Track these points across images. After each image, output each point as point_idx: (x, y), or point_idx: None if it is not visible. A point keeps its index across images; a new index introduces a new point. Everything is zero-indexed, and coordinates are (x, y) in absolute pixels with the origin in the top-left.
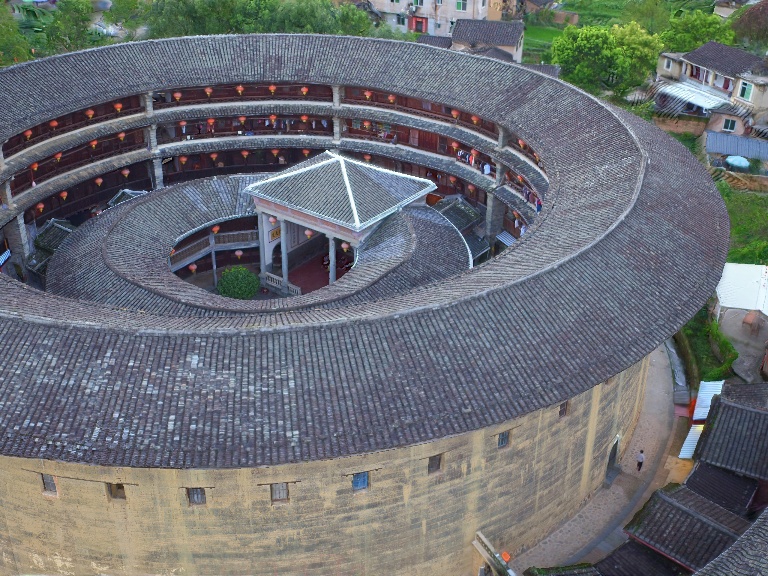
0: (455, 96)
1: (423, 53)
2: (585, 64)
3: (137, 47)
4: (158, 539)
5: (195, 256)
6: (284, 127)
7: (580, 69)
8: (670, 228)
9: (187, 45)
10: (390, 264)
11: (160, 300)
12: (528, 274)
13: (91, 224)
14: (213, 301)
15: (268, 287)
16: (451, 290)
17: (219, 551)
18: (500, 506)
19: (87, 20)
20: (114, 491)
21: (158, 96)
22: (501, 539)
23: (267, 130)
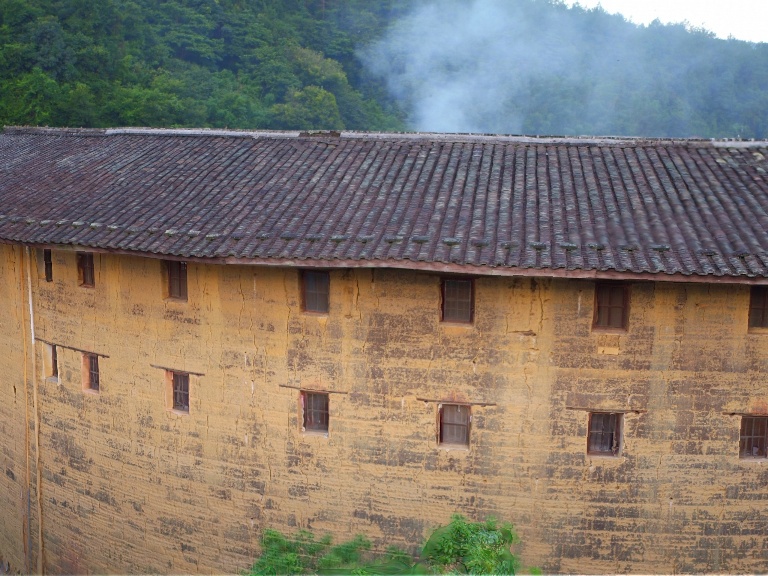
0: None
1: None
2: None
3: None
4: None
5: None
6: None
7: None
8: None
9: None
10: None
11: None
12: None
13: None
14: None
15: None
16: None
17: None
18: None
19: None
20: None
21: None
22: None
23: None
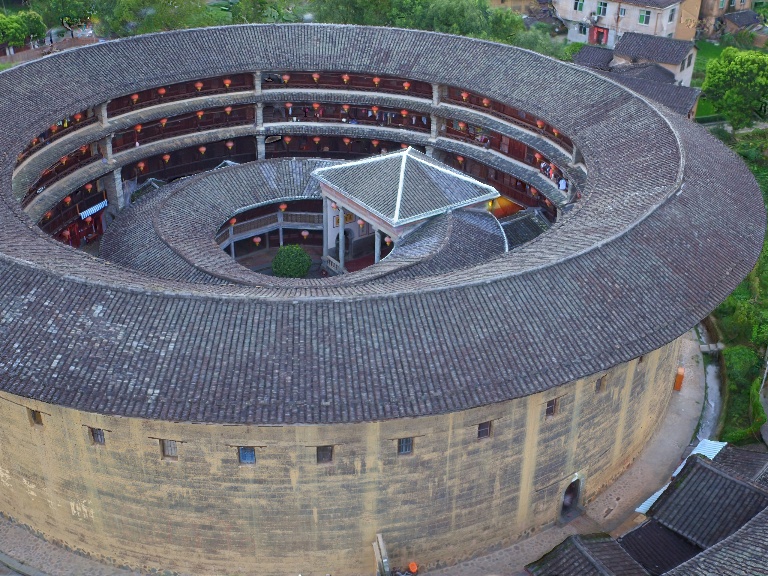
0: (541, 106)
1: (527, 59)
2: (736, 90)
3: (259, 29)
4: (70, 469)
5: (260, 230)
6: (385, 119)
7: (729, 95)
8: (657, 264)
9: (306, 31)
10: (409, 262)
11: (179, 261)
12: (451, 284)
13: (169, 186)
14: (230, 270)
15: (328, 270)
16: (385, 289)
17: (119, 492)
18: (405, 514)
19: (264, 3)
20: (39, 418)
21: (275, 77)
22: (408, 548)
23: (370, 121)
